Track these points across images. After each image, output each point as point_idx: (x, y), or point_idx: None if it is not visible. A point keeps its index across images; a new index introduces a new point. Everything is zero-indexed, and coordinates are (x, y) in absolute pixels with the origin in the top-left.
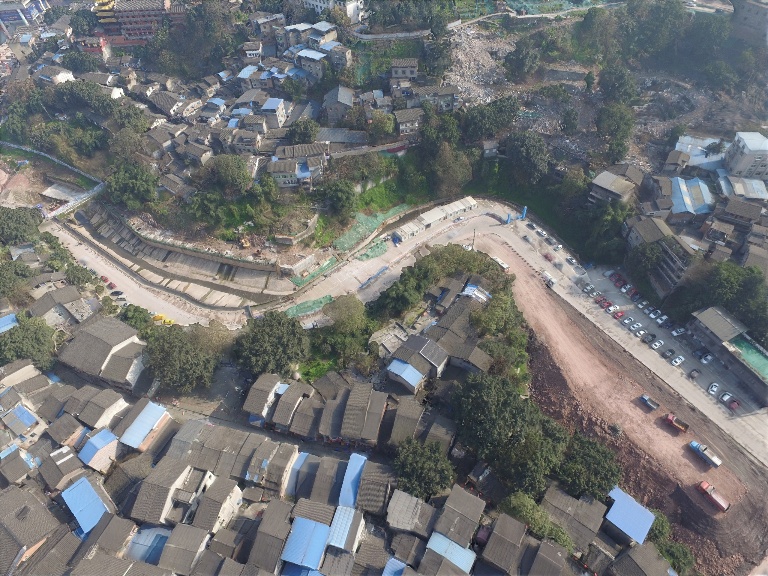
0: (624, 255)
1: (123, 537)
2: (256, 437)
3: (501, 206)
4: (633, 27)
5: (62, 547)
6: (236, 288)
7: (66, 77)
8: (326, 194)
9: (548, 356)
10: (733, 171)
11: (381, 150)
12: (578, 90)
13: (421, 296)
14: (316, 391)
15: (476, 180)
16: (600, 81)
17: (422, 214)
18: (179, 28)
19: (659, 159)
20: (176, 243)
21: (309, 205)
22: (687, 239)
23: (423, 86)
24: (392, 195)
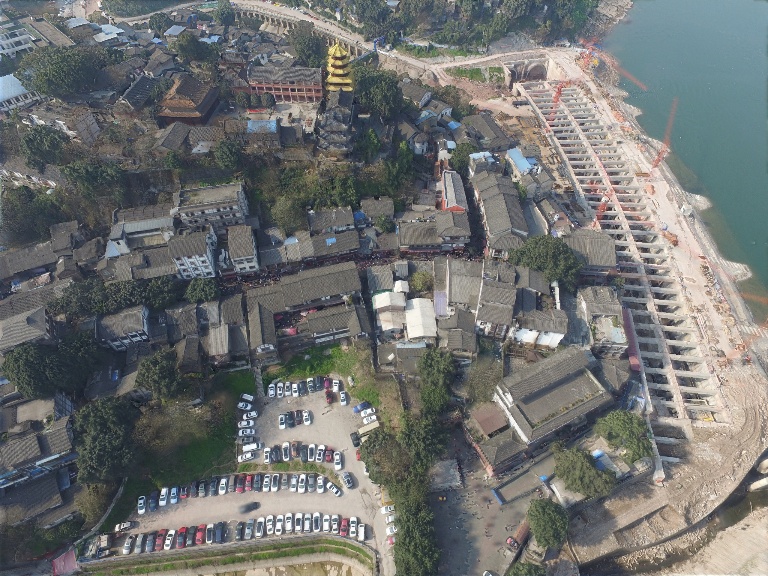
0: None
1: None
2: None
3: None
4: None
5: None
6: None
7: None
8: None
9: None
10: None
11: None
12: None
13: None
14: None
15: None
16: None
17: None
18: None
19: None
20: (280, 35)
21: None
22: None
23: None
24: None
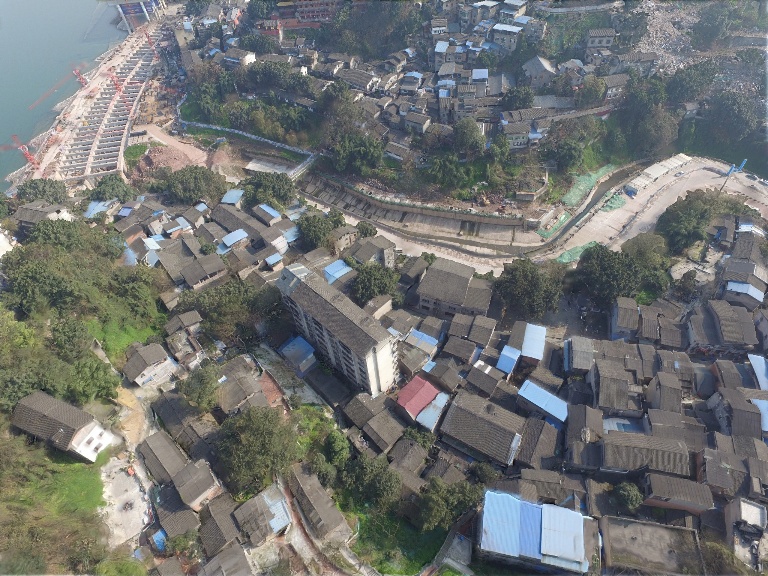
0: None
1: (601, 422)
2: (647, 347)
3: (712, 161)
4: None
5: (546, 434)
6: (484, 242)
7: (250, 58)
8: (551, 154)
9: None
10: None
11: (592, 113)
12: (766, 54)
13: None
14: None
15: None
16: None
17: (645, 170)
18: (358, 9)
19: None
20: (416, 204)
21: (537, 165)
22: None
23: None
24: (599, 156)
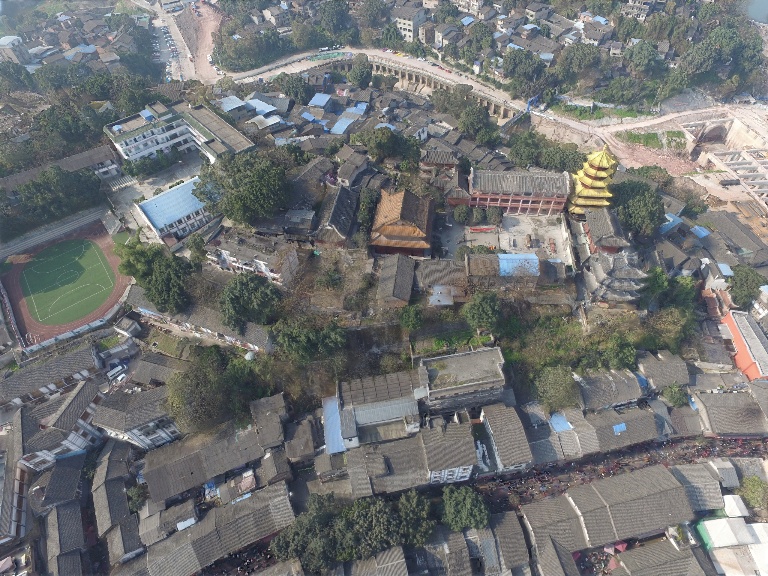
0: None
1: None
2: None
3: None
4: None
5: None
6: None
7: None
8: None
9: None
10: (31, 57)
11: None
12: None
13: None
14: None
15: None
16: None
17: None
18: None
19: None
20: (411, 91)
21: None
22: (113, 35)
23: None
24: None
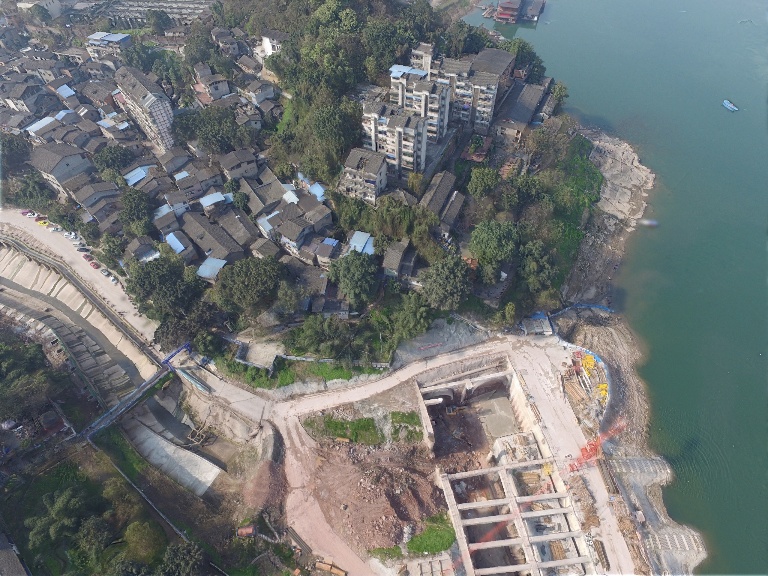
0: None
1: None
2: None
3: None
4: None
5: None
6: None
7: None
8: None
9: None
10: None
11: None
12: None
13: None
14: None
15: None
16: None
17: None
18: None
19: None
20: (13, 312)
21: None
22: None
23: None
24: None
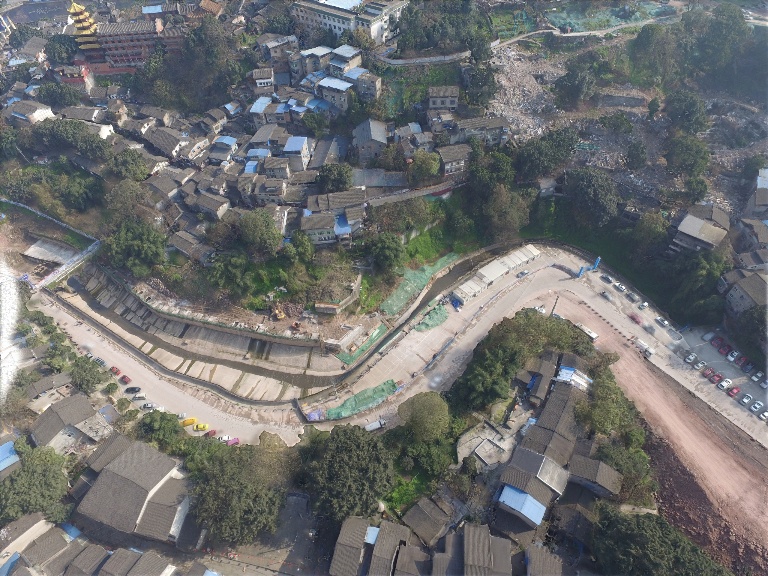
0: (723, 314)
1: None
2: None
3: (566, 254)
4: (692, 45)
5: None
6: (273, 369)
7: (44, 114)
8: (368, 250)
9: (673, 457)
10: None
11: (425, 194)
12: (638, 117)
13: (508, 384)
14: (411, 531)
15: (531, 222)
16: (665, 108)
17: (481, 269)
18: (174, 54)
19: (736, 194)
20: (196, 316)
21: (350, 264)
22: None
23: (465, 117)
24: (438, 244)
